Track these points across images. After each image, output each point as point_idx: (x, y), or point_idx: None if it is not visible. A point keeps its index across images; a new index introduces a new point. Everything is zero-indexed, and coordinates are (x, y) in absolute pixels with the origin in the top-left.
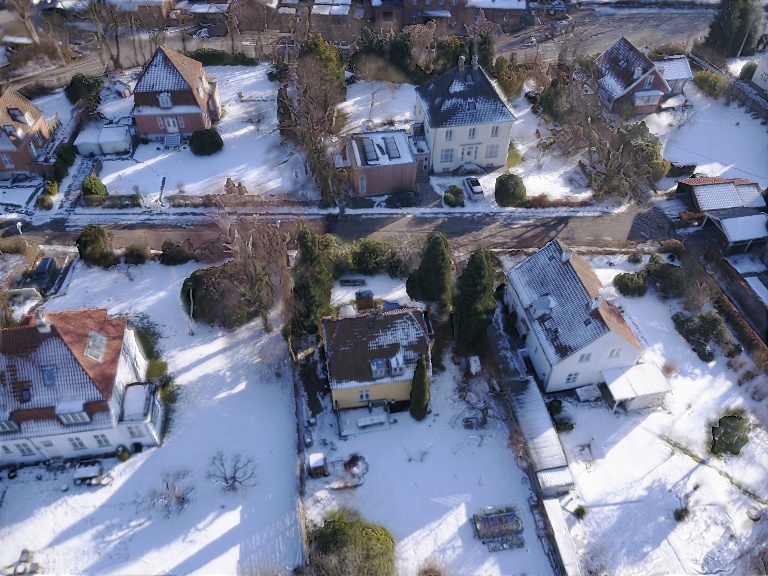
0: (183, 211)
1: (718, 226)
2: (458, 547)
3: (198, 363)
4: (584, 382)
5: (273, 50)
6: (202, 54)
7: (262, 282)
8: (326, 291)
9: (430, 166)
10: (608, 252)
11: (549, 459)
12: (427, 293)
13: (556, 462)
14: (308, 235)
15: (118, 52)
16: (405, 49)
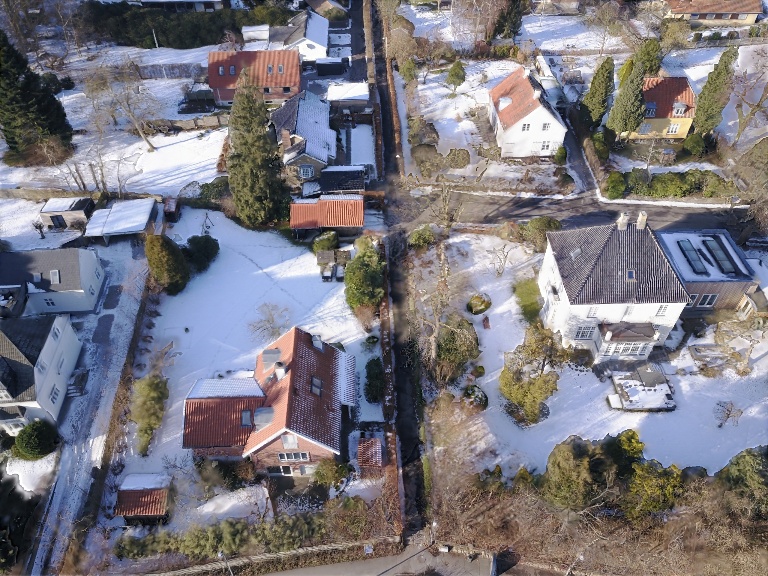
0: None
1: None
2: (591, 79)
3: (767, 133)
4: None
5: None
6: None
7: None
8: None
9: None
10: (461, 187)
11: (550, 82)
12: None
13: (546, 81)
14: None
15: None
16: None
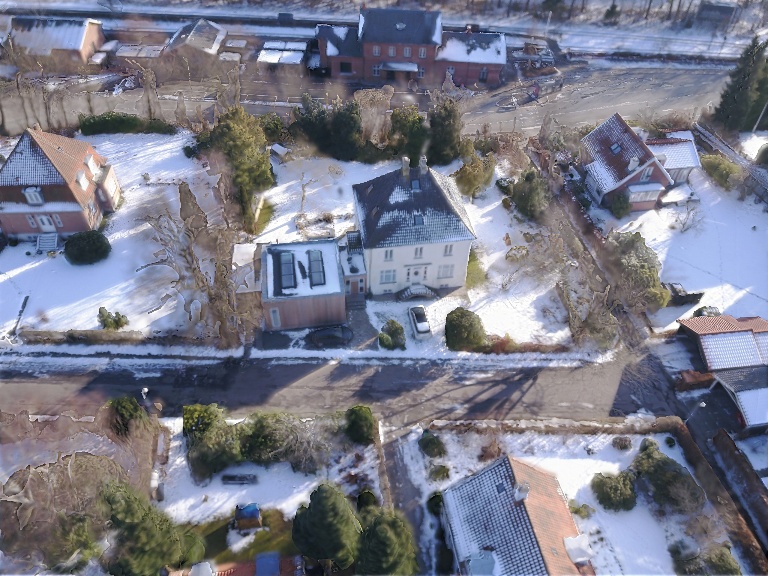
0: (40, 350)
1: (732, 397)
2: None
3: None
4: None
5: (197, 114)
6: (108, 120)
7: (84, 522)
8: (167, 551)
9: (367, 288)
10: (587, 430)
11: None
12: (317, 550)
13: None
14: (118, 504)
15: (3, 117)
16: (352, 123)
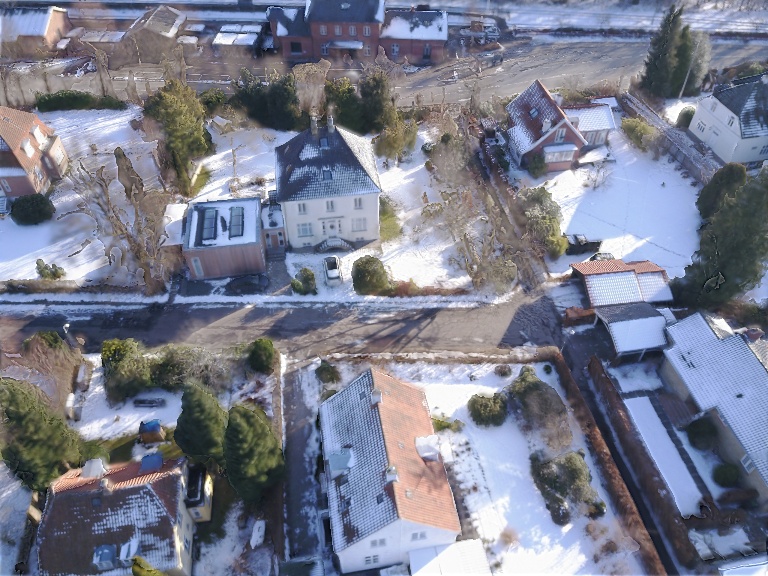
0: None
1: (607, 329)
2: None
3: None
4: (391, 561)
5: (147, 91)
6: (62, 97)
7: None
8: (60, 446)
9: (286, 241)
10: (473, 360)
11: None
12: (193, 446)
13: None
14: (2, 393)
15: None
16: (285, 94)
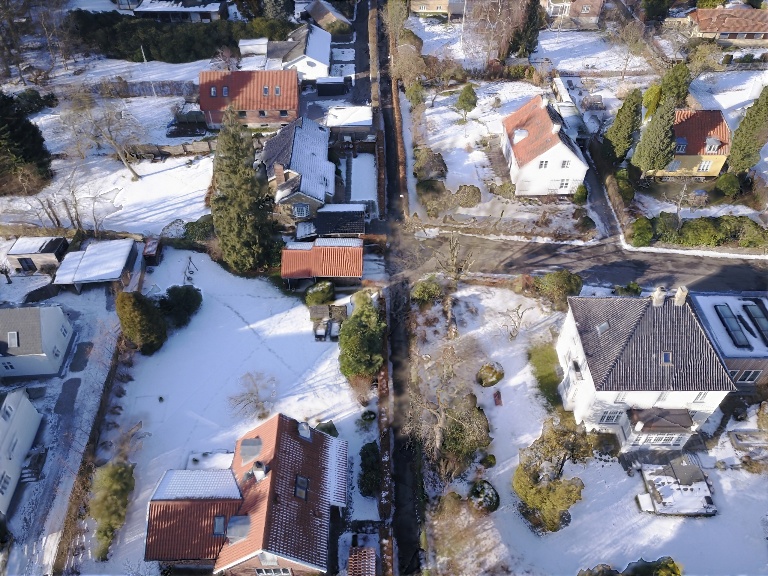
0: None
1: None
2: (613, 105)
3: None
4: None
5: None
6: None
7: None
8: None
9: None
10: (471, 230)
11: None
12: None
13: None
14: None
15: None
16: None
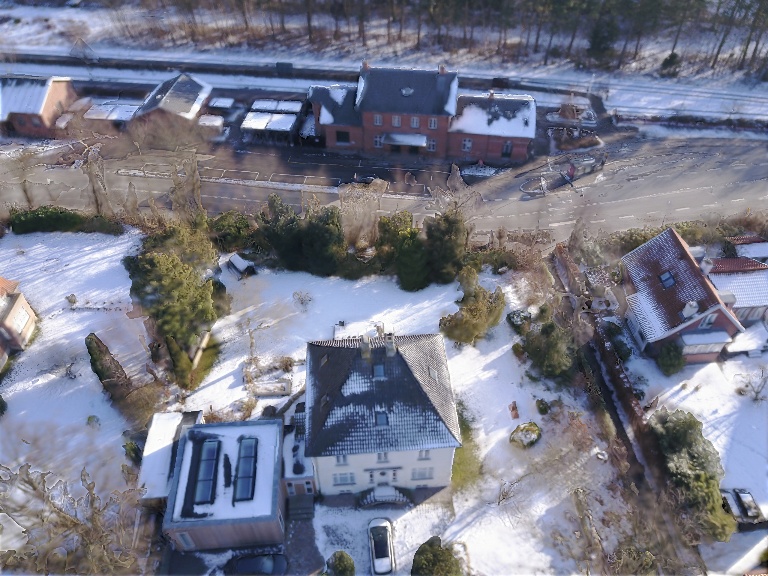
0: None
1: None
2: None
3: None
4: None
5: None
6: (42, 217)
7: None
8: None
9: (317, 489)
10: None
11: None
12: None
13: None
14: None
15: None
16: (326, 235)
